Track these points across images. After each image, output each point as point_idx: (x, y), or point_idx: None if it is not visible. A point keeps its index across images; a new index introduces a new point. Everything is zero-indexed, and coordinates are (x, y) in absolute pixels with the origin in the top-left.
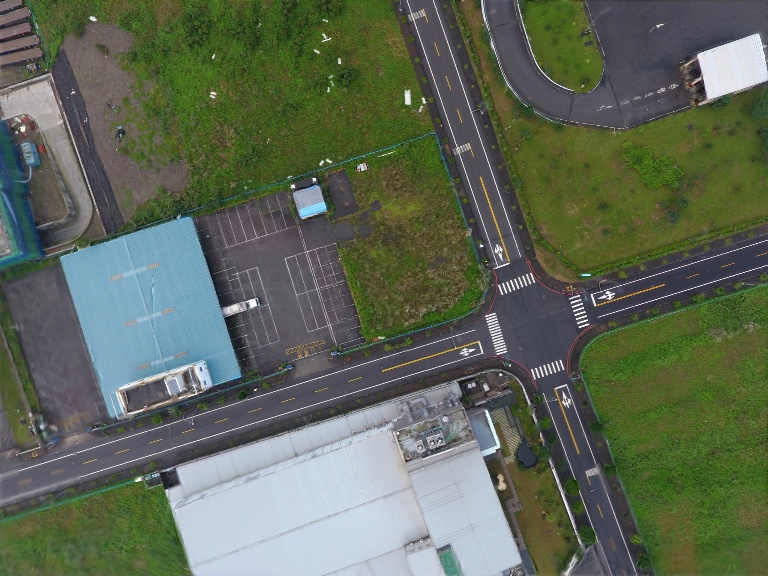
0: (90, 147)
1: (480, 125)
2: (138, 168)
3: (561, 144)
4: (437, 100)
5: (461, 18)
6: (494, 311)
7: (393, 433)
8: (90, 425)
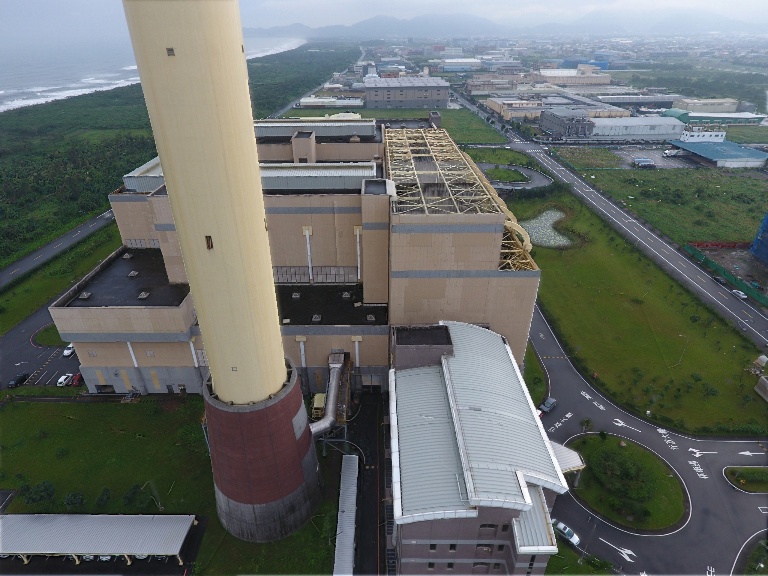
0: None
1: None
2: None
3: None
4: None
5: None
6: None
7: None
8: None
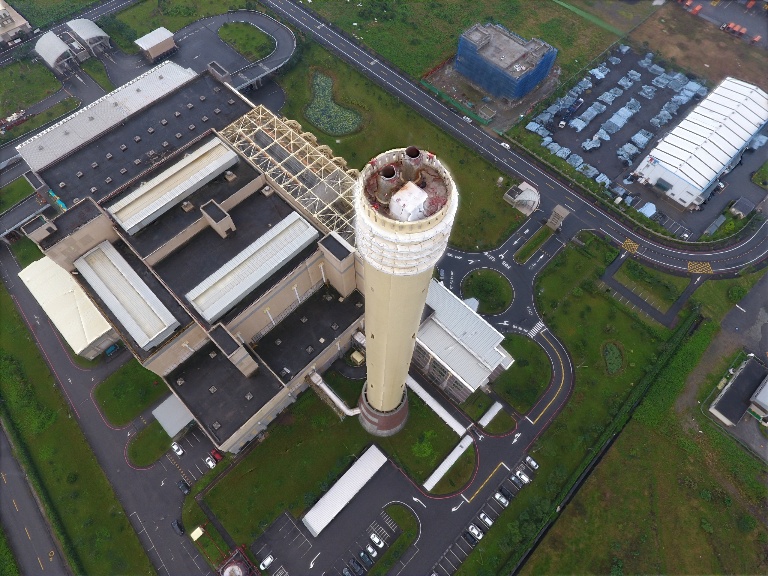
0: None
1: (270, 3)
2: None
3: (227, 7)
4: (295, 4)
5: None
6: None
7: None
8: None
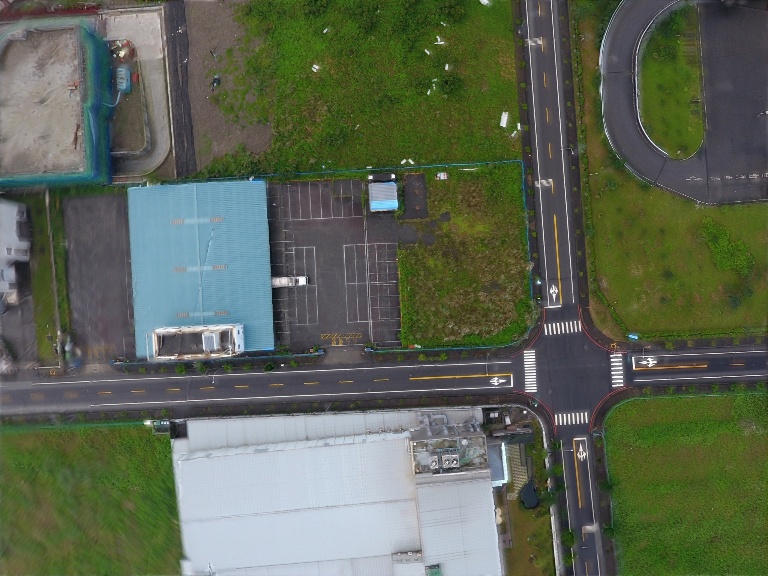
0: (183, 88)
1: (567, 164)
2: (224, 121)
3: (642, 203)
4: (532, 129)
5: (576, 55)
6: (534, 349)
7: (410, 442)
8: (113, 358)
